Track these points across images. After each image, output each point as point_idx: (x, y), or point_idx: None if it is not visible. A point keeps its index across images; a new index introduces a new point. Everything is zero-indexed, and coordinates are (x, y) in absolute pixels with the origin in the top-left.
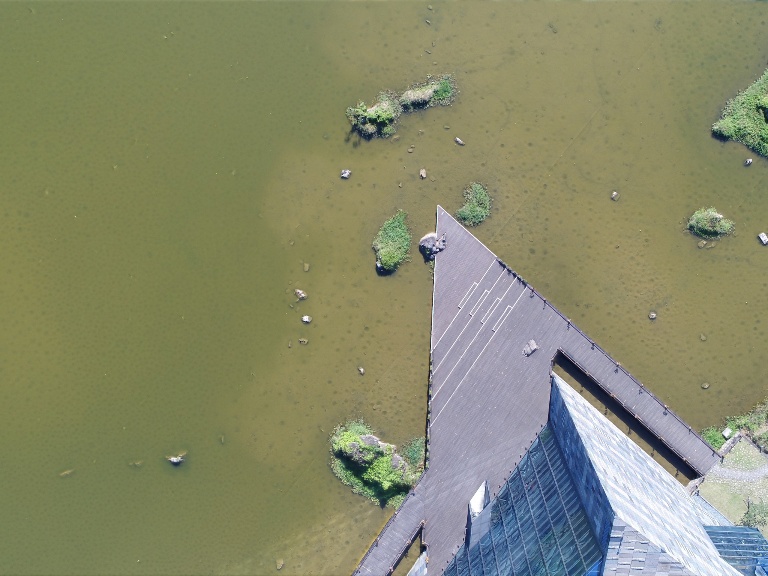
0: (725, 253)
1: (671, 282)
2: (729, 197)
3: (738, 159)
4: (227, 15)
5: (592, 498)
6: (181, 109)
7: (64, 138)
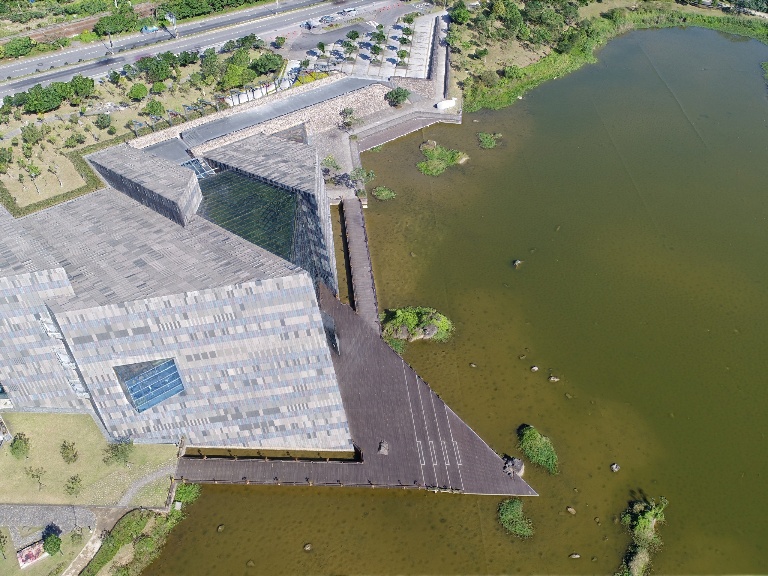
0: None
1: None
2: None
3: None
4: None
5: None
6: (746, 427)
7: None
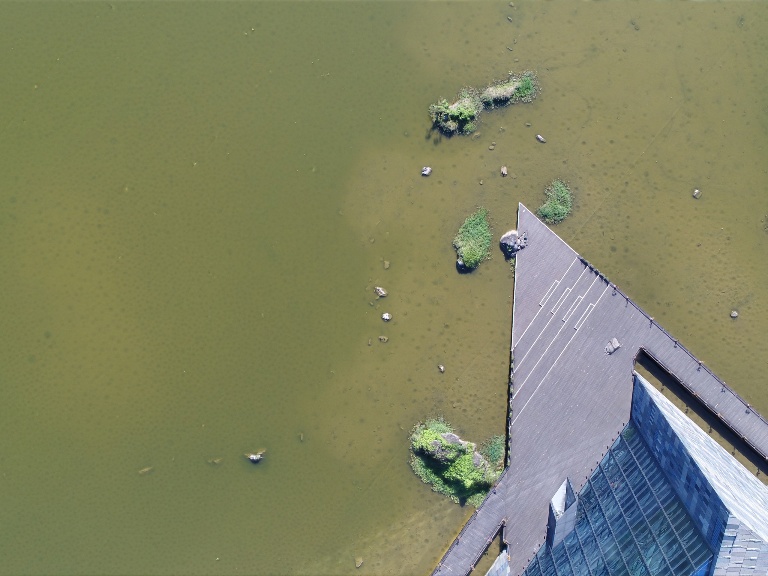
0: None
1: (753, 280)
2: None
3: None
4: (308, 12)
5: (696, 496)
6: (261, 106)
7: (144, 135)
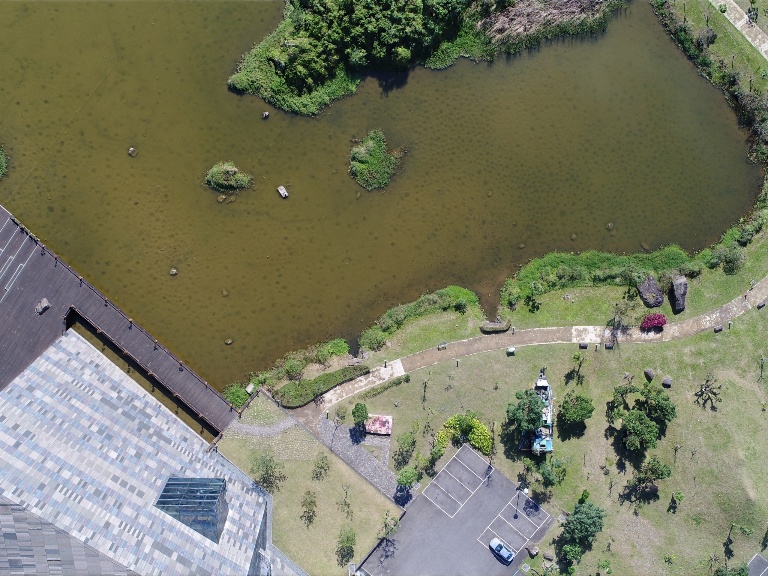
0: (245, 207)
1: (191, 237)
2: (248, 151)
3: (256, 112)
4: None
5: None
6: None
7: None
